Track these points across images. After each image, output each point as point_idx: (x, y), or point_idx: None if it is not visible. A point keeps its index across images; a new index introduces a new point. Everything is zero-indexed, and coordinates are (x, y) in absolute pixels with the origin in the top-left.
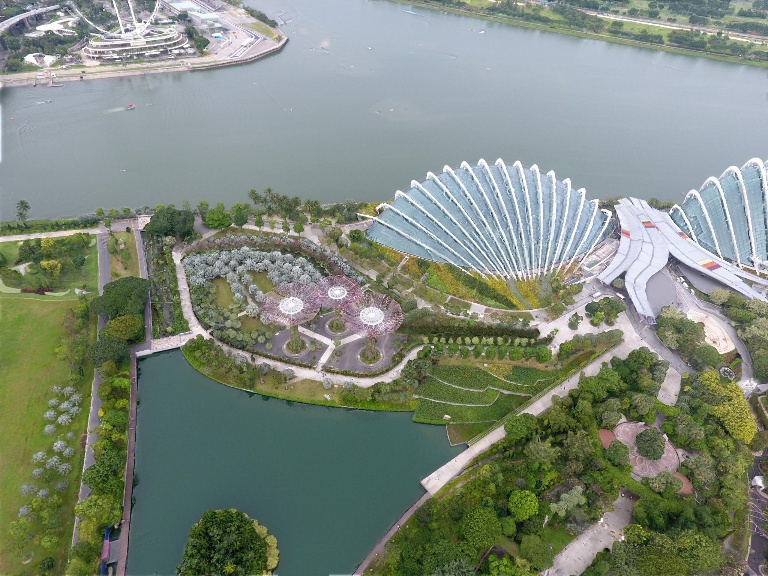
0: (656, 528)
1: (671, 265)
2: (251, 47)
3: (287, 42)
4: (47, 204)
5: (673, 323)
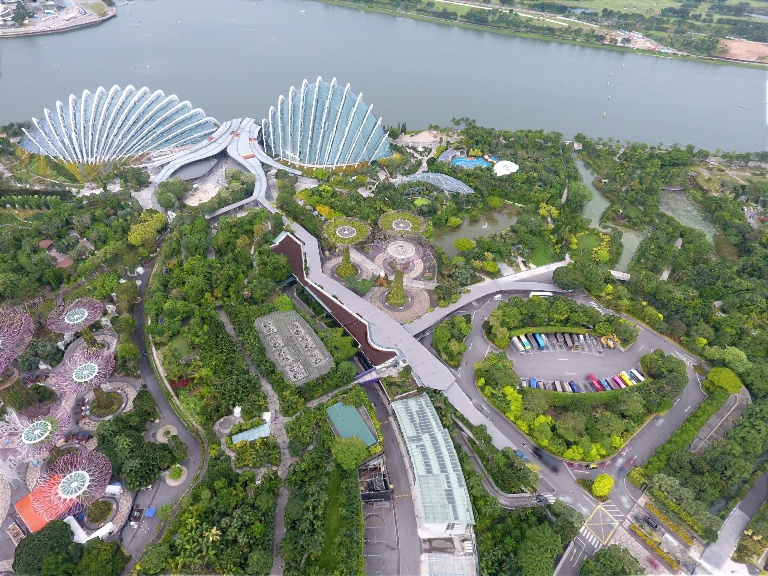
0: None
1: None
2: (71, 21)
3: (113, 18)
4: None
5: (167, 185)
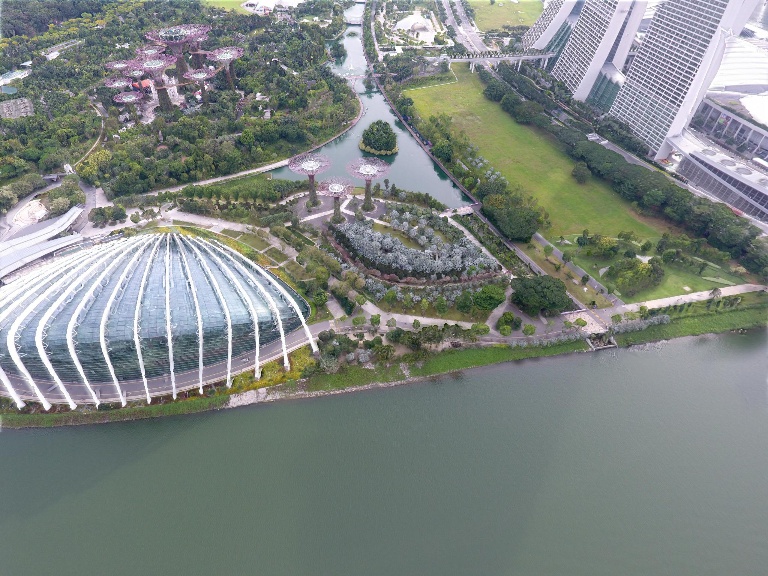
0: None
1: None
2: None
3: None
4: (764, 368)
5: None
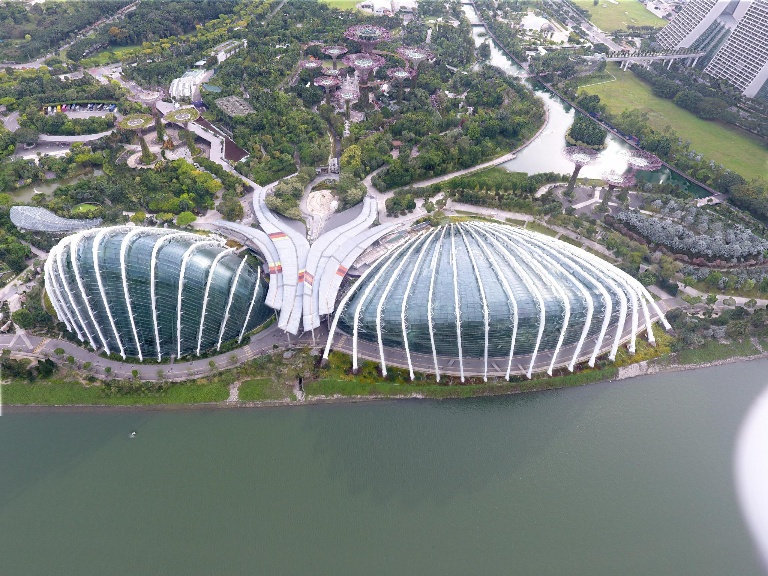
0: None
1: None
2: None
3: None
4: None
5: None
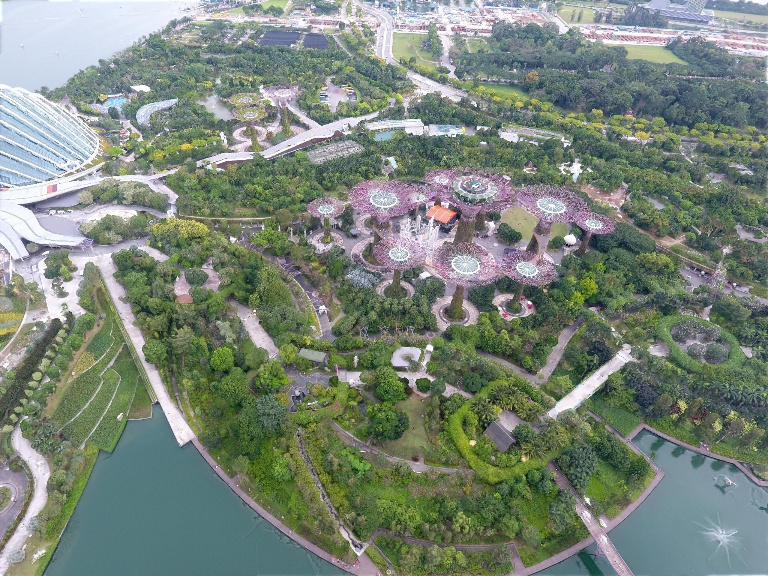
0: (252, 291)
1: (32, 211)
2: None
3: None
4: None
5: (99, 229)
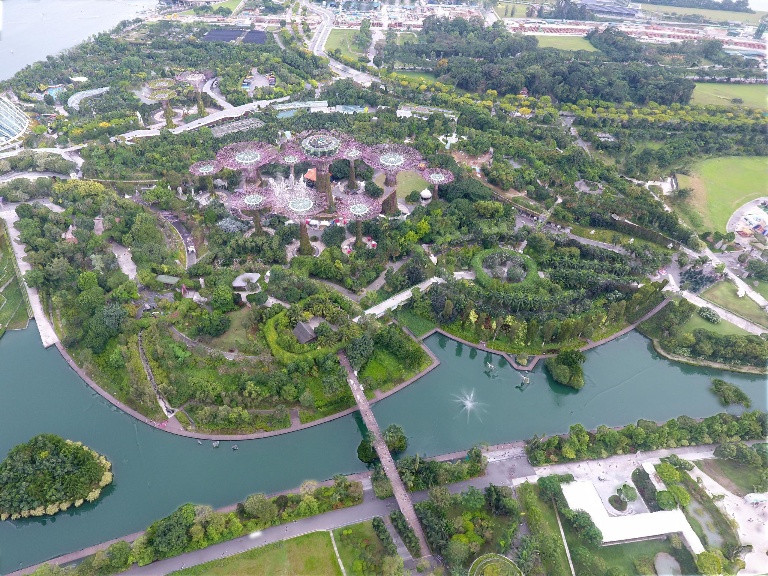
0: None
1: None
2: None
3: None
4: None
5: (8, 189)
